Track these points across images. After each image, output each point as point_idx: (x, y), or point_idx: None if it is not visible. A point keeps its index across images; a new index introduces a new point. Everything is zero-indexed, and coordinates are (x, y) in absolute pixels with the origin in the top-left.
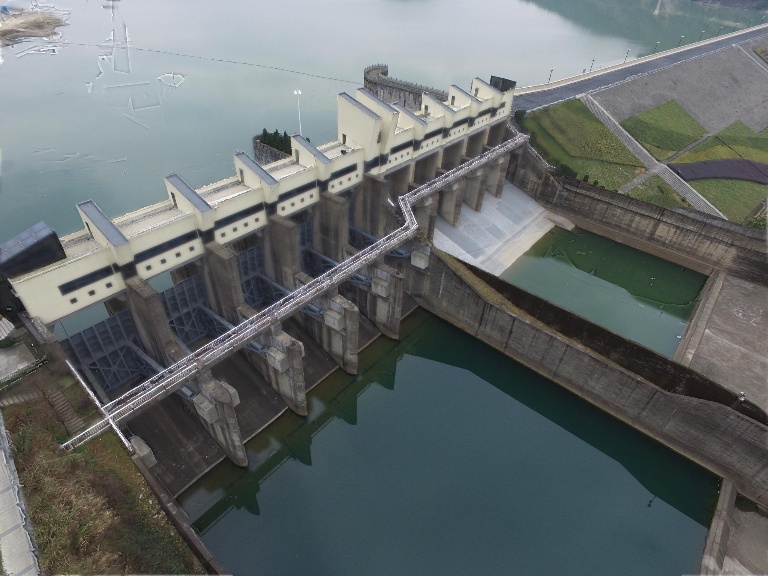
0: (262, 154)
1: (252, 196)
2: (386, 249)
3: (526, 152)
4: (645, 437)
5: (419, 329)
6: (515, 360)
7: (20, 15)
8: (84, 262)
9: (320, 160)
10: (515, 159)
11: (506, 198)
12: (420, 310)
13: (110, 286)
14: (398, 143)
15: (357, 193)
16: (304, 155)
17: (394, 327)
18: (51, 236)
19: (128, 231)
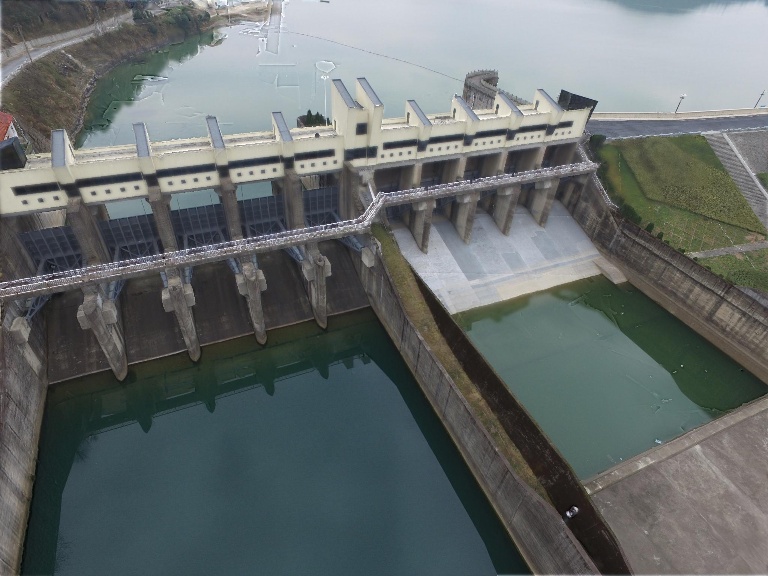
0: None
1: (202, 155)
2: (323, 235)
3: (591, 183)
4: (499, 522)
5: (355, 327)
6: (421, 388)
7: (248, 3)
8: (33, 174)
9: (282, 137)
10: (579, 189)
11: (553, 229)
12: (369, 310)
13: (57, 199)
14: (395, 139)
15: (340, 180)
16: (276, 131)
17: (320, 314)
18: (11, 147)
19: None
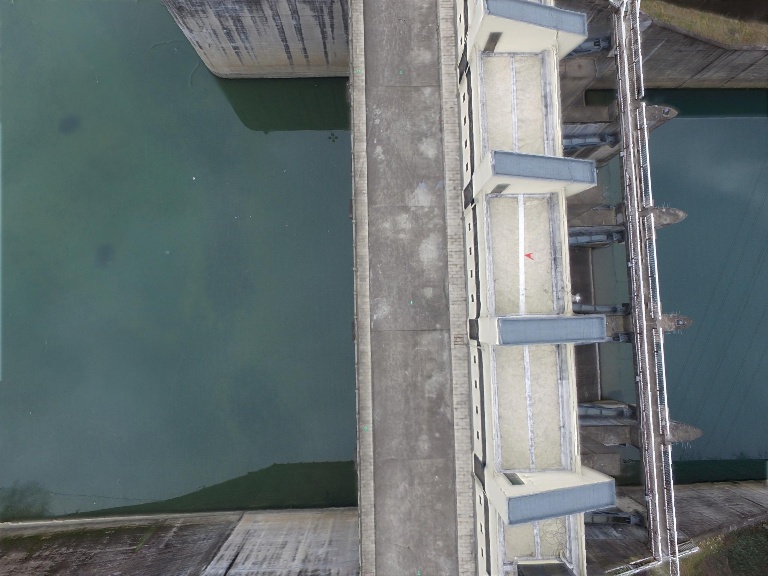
0: (201, 2)
1: None
2: None
3: None
4: None
5: None
6: (735, 89)
7: None
8: None
9: (572, 32)
10: None
11: None
12: (589, 95)
13: None
14: None
15: None
16: (519, 36)
17: None
18: None
19: (520, 444)
